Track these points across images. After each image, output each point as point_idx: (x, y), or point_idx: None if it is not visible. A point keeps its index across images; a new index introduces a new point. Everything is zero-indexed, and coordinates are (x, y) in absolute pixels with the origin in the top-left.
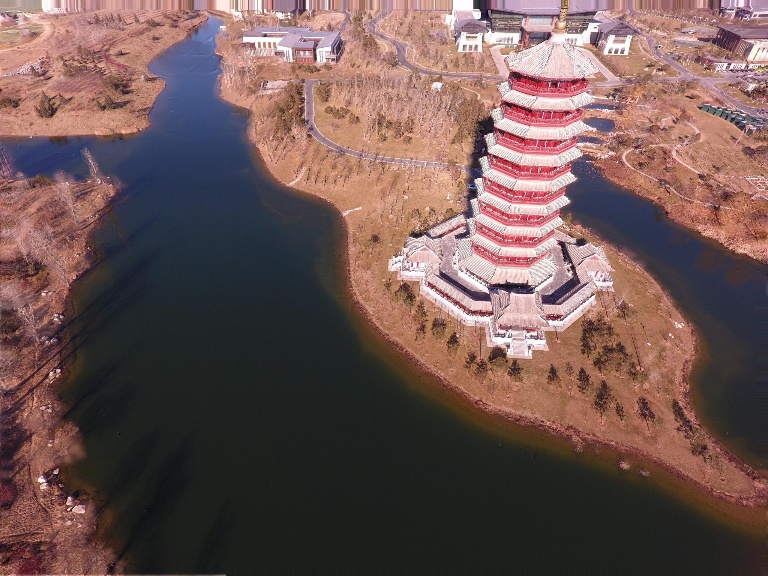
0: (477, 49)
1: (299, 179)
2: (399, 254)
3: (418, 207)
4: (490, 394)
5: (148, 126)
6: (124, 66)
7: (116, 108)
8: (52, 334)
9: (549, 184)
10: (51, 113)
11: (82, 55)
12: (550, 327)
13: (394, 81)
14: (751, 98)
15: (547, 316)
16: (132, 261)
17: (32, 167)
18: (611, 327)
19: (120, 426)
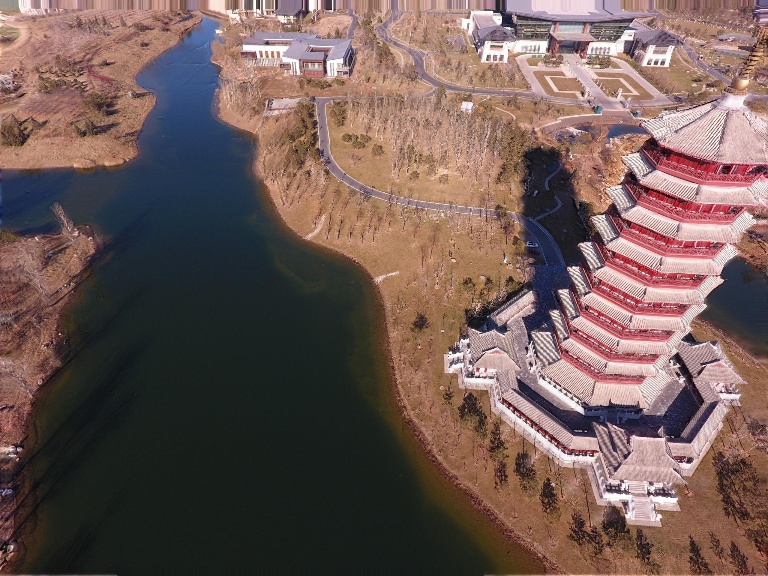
0: (502, 59)
1: (318, 230)
2: (455, 346)
3: (470, 275)
4: None
5: (136, 155)
6: (109, 79)
7: (98, 134)
8: (5, 481)
9: (692, 293)
10: (22, 140)
11: (61, 67)
12: None
13: None
14: None
15: None
16: (115, 355)
17: None
18: (753, 467)
19: None
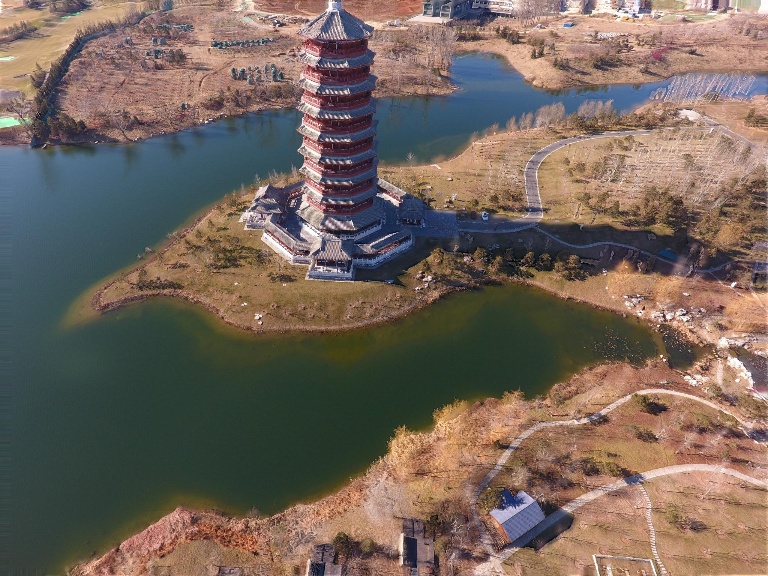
0: None
1: None
2: None
3: (432, 184)
4: None
5: (554, 89)
6: (656, 57)
7: (563, 70)
8: None
9: None
10: (538, 57)
11: (650, 40)
12: None
13: None
14: None
15: None
16: None
17: (467, 72)
18: None
19: (245, 124)
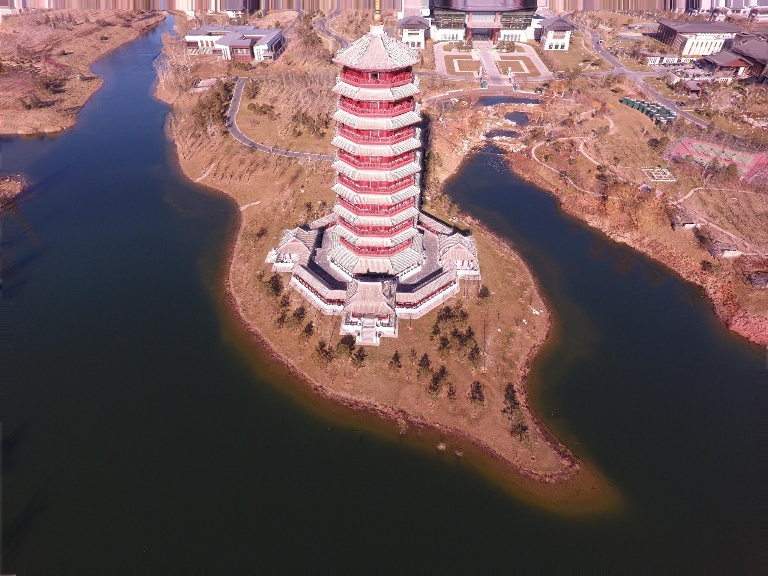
0: (420, 46)
1: (206, 175)
2: None
3: (311, 201)
4: (331, 380)
5: (73, 125)
6: (62, 66)
7: (42, 107)
8: None
9: (389, 174)
10: None
11: (20, 55)
12: (406, 315)
13: (320, 78)
14: (674, 91)
15: (403, 304)
16: (18, 256)
17: None
18: (466, 314)
19: None
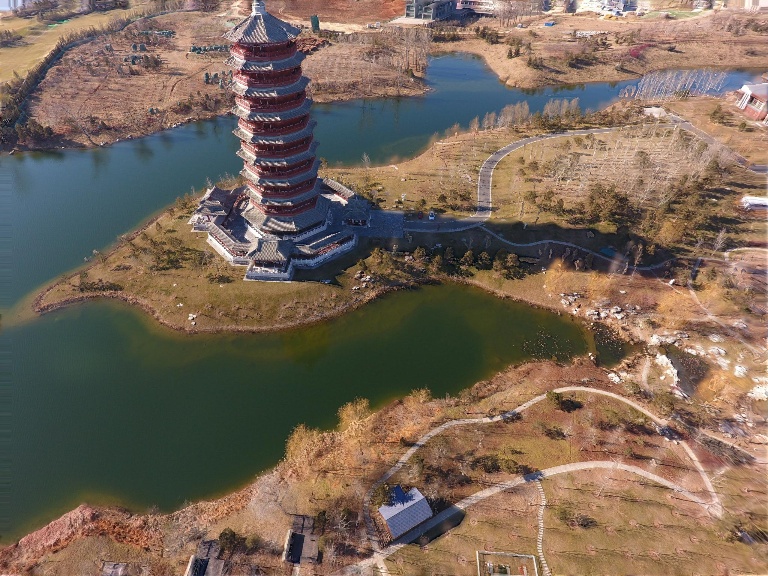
0: None
1: (444, 144)
2: None
3: (384, 184)
4: None
5: (527, 88)
6: (633, 55)
7: (537, 69)
8: None
9: None
10: (514, 57)
11: None
12: None
13: None
14: None
15: None
16: None
17: (442, 72)
18: None
19: (212, 128)
